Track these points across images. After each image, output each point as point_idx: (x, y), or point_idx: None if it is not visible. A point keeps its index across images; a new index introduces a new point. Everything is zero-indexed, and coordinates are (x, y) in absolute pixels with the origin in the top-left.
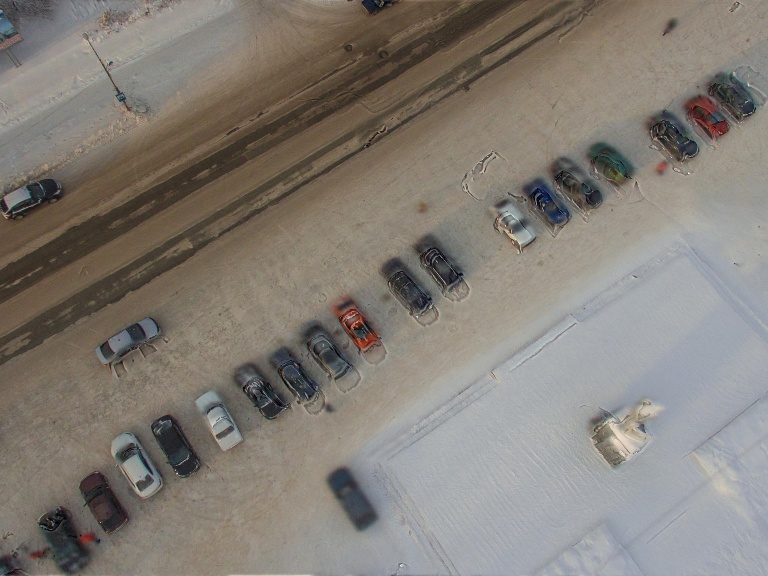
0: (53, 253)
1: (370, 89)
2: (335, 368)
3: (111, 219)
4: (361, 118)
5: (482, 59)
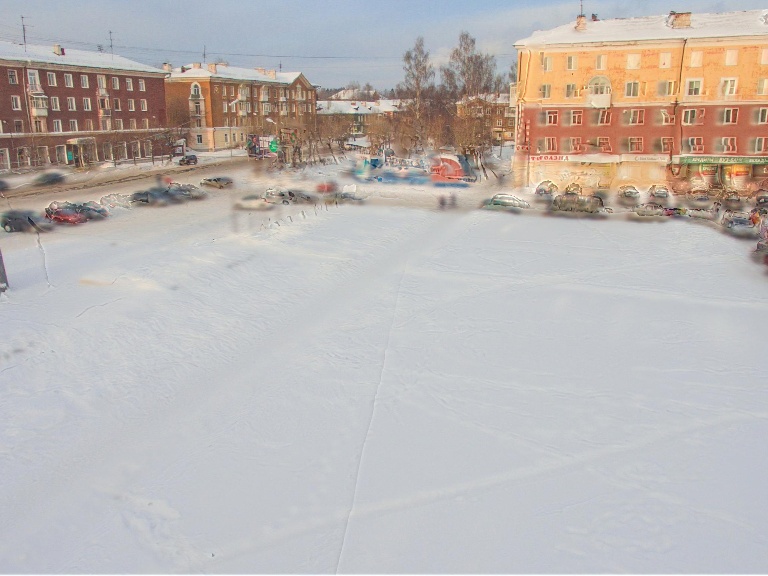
0: None
1: None
2: None
3: None
4: None
5: None
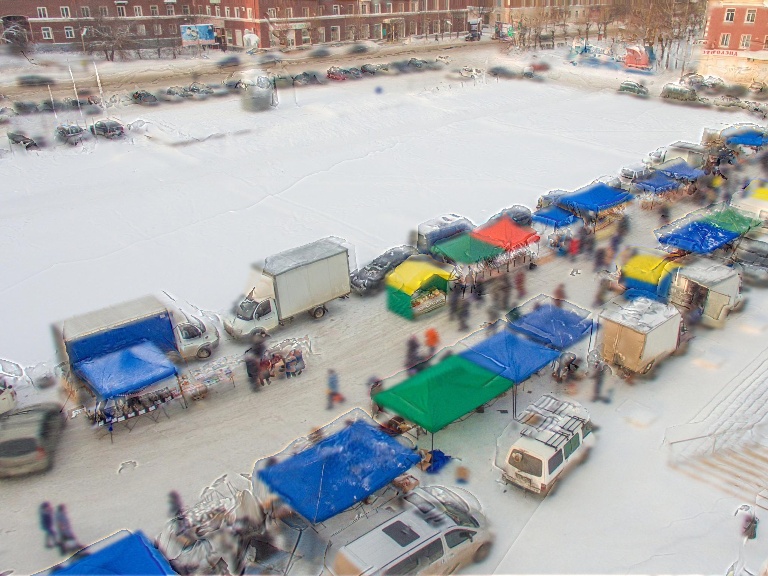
0: None
1: None
2: (123, 98)
3: (8, 90)
4: None
5: (245, 71)
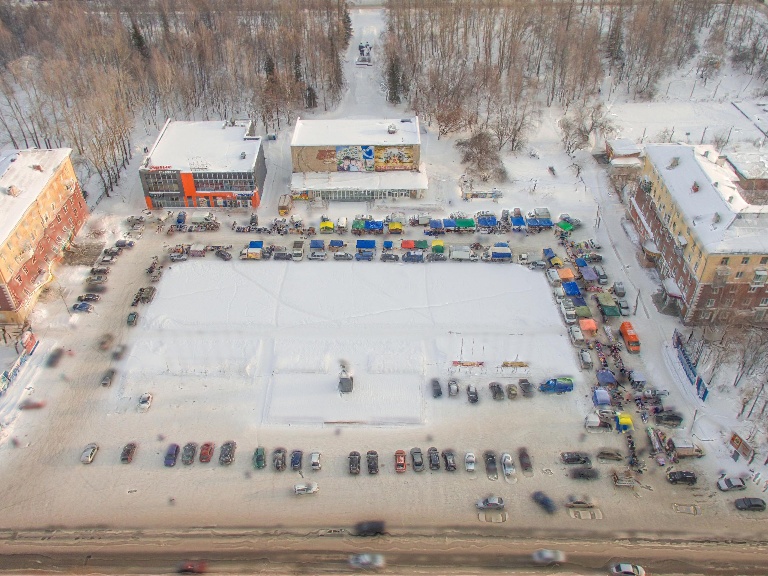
0: (513, 575)
1: (316, 565)
2: None
3: (478, 574)
4: (335, 544)
5: (256, 542)
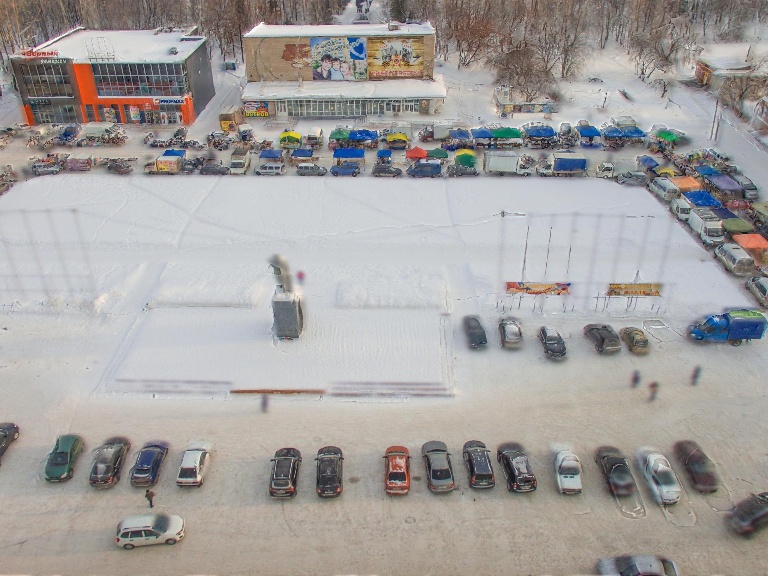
0: None
1: None
2: None
3: None
4: None
5: None
